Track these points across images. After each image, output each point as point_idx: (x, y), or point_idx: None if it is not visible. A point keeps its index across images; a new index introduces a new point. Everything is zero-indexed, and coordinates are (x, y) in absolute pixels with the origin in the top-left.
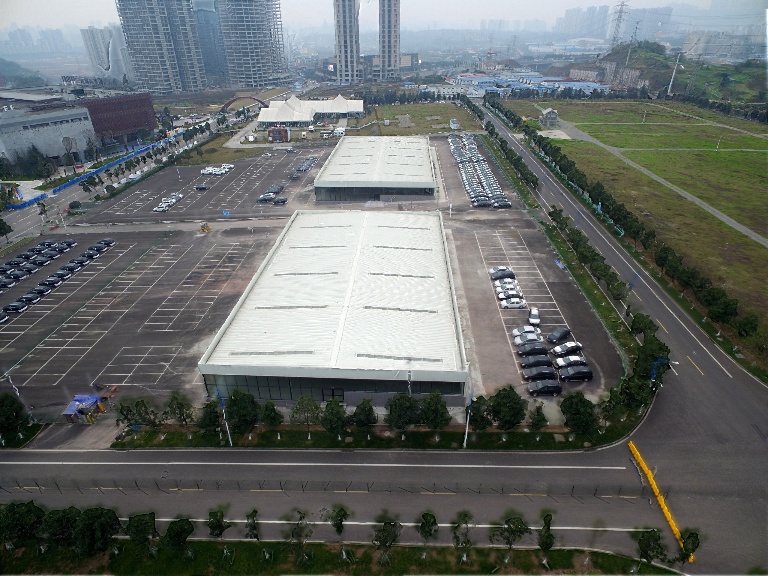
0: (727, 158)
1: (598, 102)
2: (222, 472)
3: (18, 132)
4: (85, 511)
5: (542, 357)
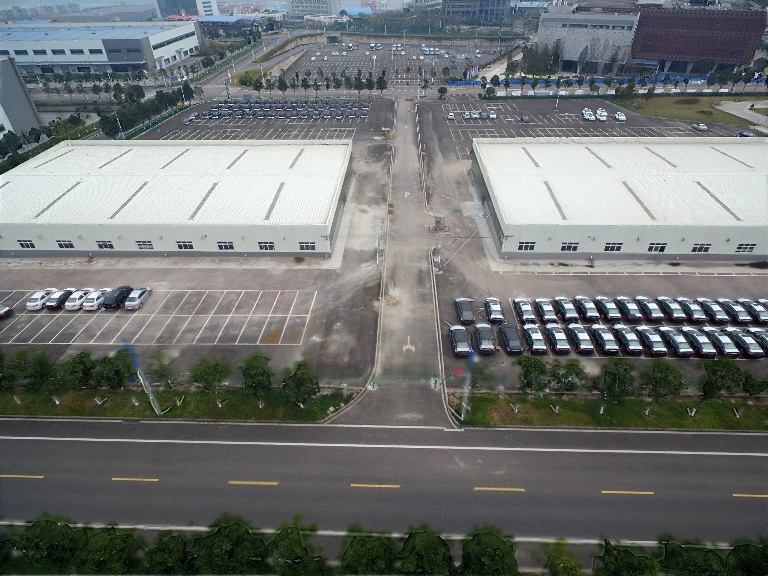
0: None
1: None
2: None
3: (555, 28)
4: None
5: None
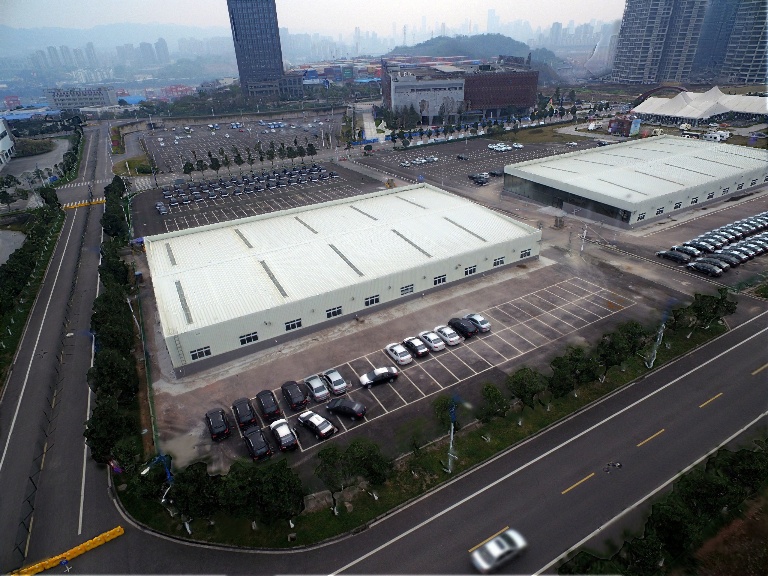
0: None
1: None
2: (88, 305)
3: (406, 93)
4: None
5: (268, 400)
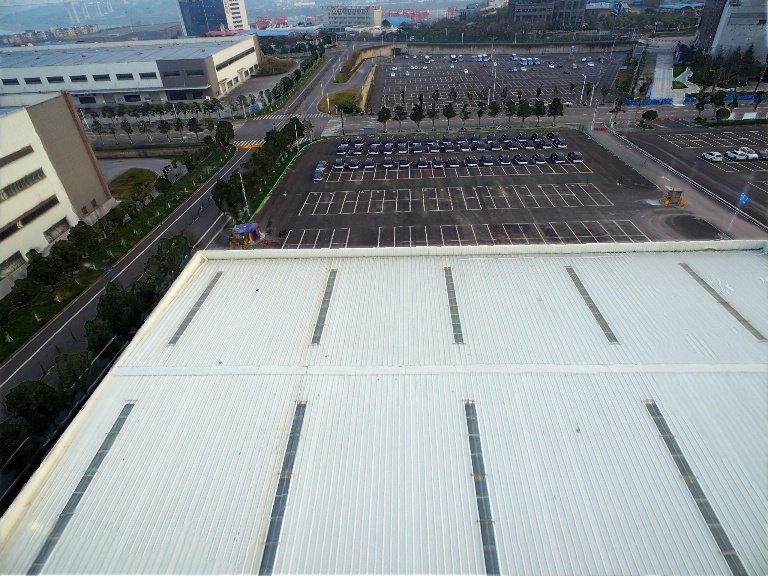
0: None
1: None
2: None
3: (748, 26)
4: None
5: None
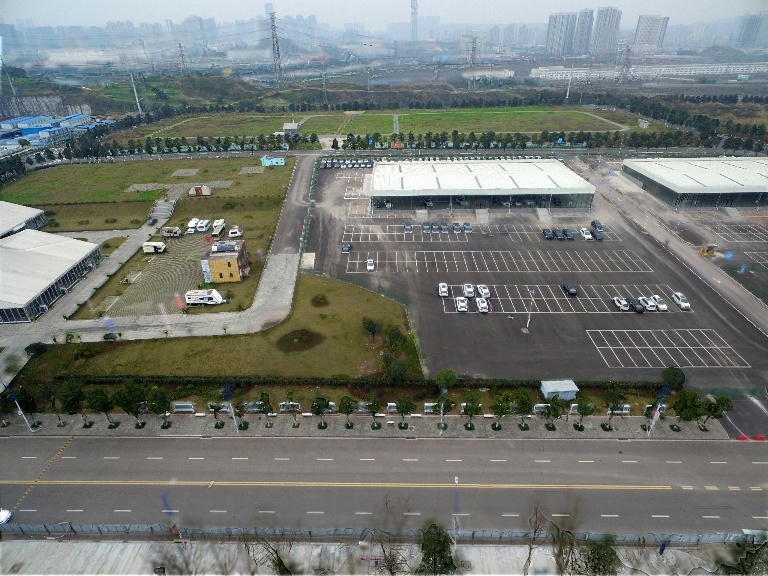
0: (422, 122)
1: (174, 124)
2: None
3: None
4: None
5: None
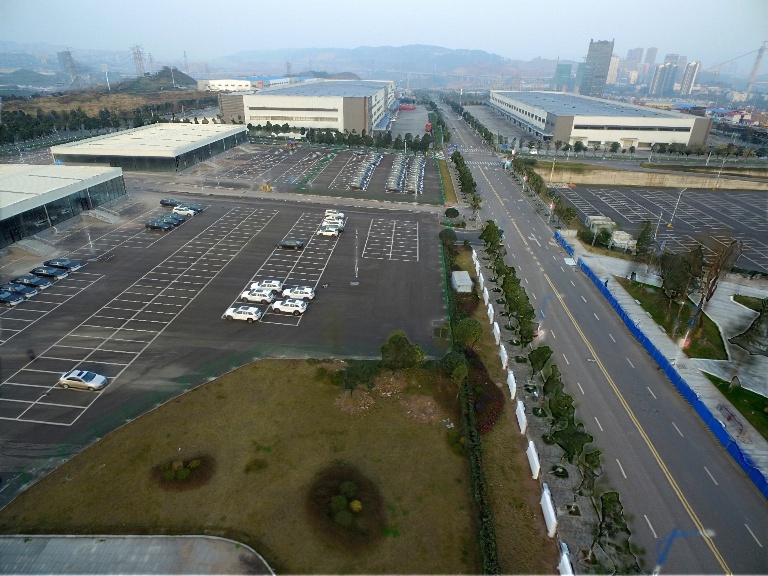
0: None
1: None
2: None
3: None
4: (268, 121)
5: None
